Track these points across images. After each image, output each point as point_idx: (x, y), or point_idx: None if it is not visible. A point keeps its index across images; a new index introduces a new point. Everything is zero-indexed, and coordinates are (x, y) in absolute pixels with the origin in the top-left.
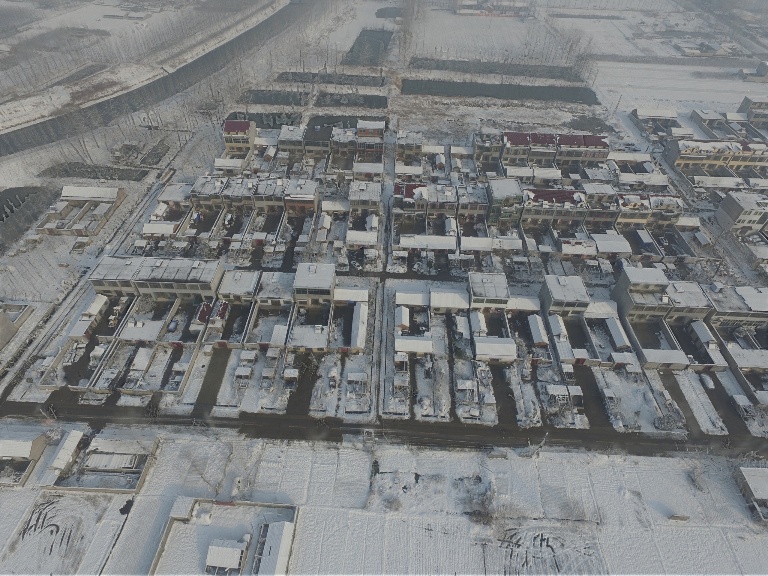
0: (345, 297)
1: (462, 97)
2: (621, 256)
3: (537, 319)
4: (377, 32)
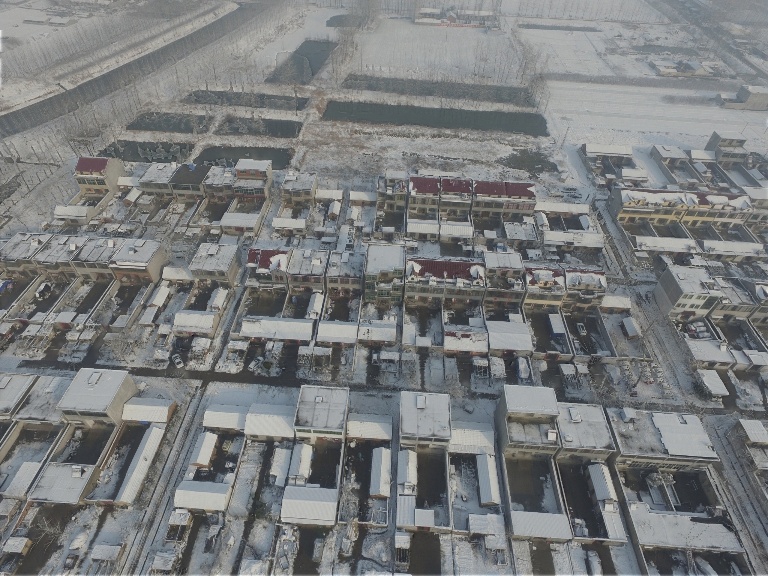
0: (137, 416)
1: (388, 125)
2: (520, 354)
3: (382, 456)
4: (321, 43)
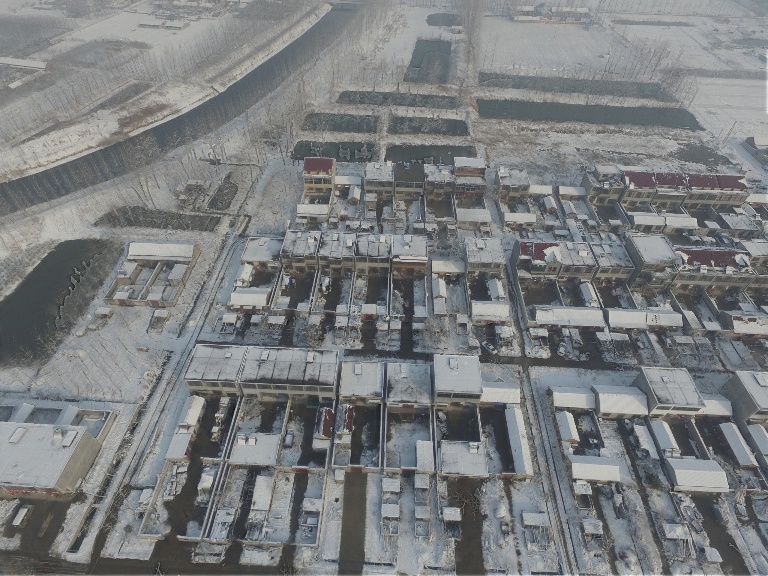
0: (492, 398)
1: (550, 122)
2: None
3: (735, 430)
4: (433, 42)
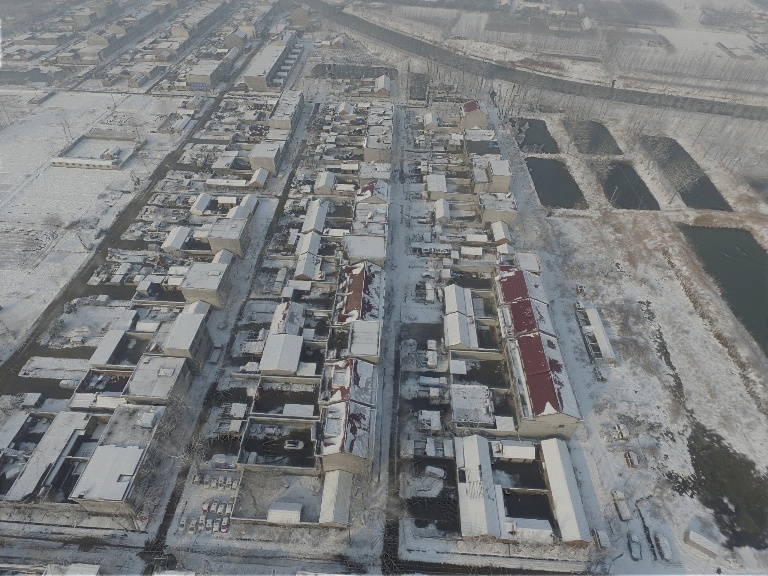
0: None
1: None
2: None
3: None
4: None
